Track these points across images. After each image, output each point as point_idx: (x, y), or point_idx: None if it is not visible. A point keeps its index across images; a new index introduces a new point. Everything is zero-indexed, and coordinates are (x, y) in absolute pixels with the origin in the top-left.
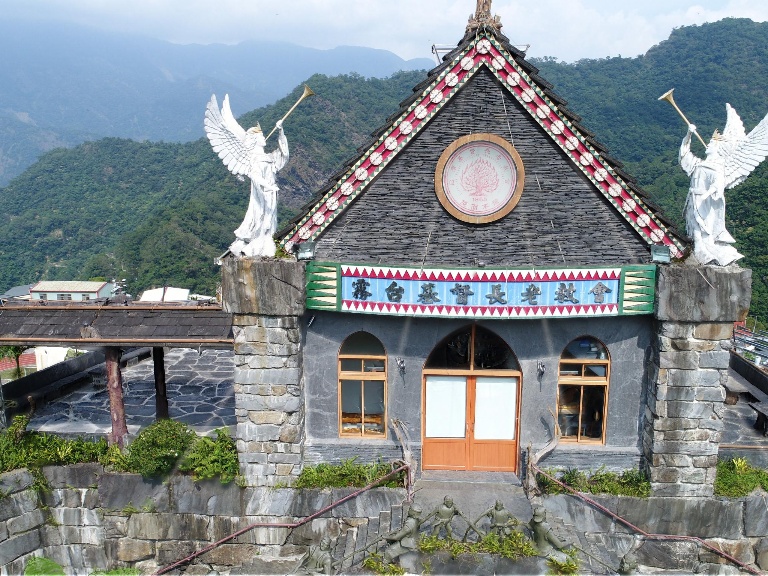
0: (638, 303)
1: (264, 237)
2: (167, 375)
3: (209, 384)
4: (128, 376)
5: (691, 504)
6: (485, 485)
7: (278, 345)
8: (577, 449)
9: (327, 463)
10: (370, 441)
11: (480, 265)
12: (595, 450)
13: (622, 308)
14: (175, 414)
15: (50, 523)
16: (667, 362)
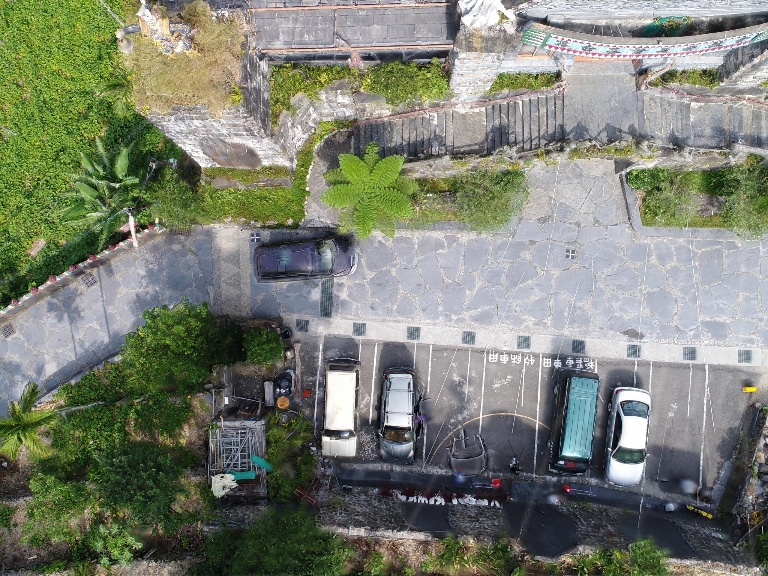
0: (767, 36)
1: (490, 12)
2: None
3: None
4: None
5: (740, 88)
6: (611, 77)
7: (490, 57)
8: (681, 62)
9: (506, 72)
10: (538, 62)
11: (659, 44)
12: (693, 63)
13: (753, 41)
14: None
15: (316, 99)
16: (767, 53)
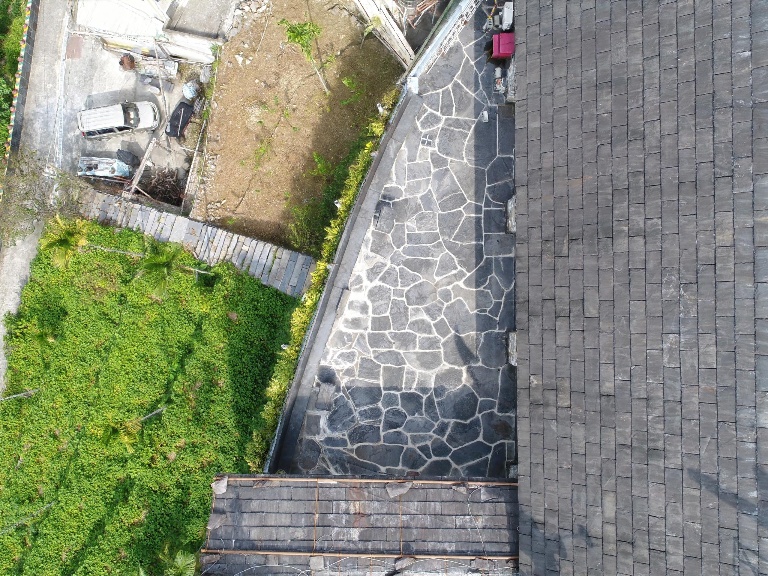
0: None
1: None
2: (375, 365)
3: (424, 389)
4: (338, 368)
5: None
6: None
7: None
8: None
9: None
10: None
11: None
12: None
13: None
14: (418, 463)
15: None
16: None
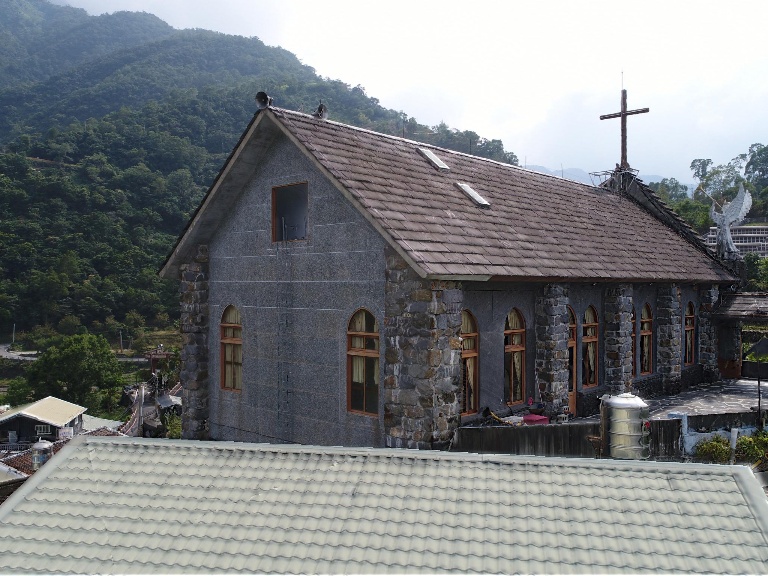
0: None
1: None
2: None
3: None
4: None
5: None
6: None
7: None
8: None
9: None
10: None
11: None
12: None
13: None
14: None
15: None
16: None
